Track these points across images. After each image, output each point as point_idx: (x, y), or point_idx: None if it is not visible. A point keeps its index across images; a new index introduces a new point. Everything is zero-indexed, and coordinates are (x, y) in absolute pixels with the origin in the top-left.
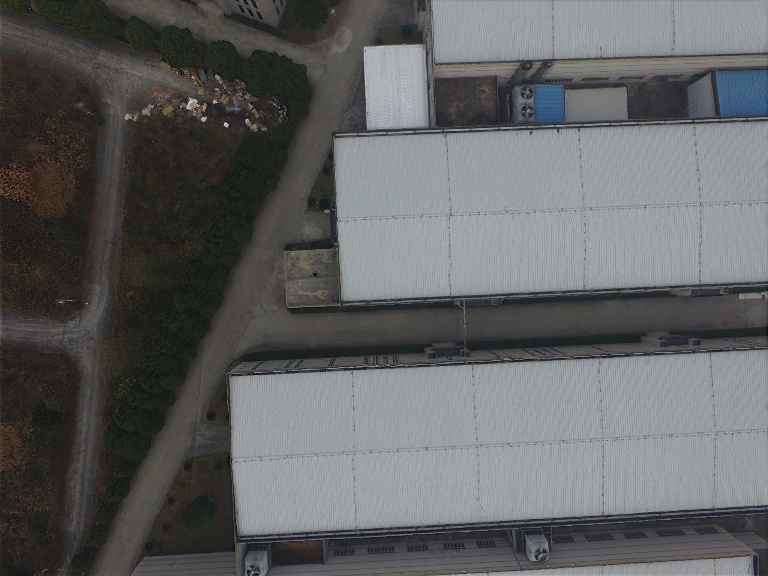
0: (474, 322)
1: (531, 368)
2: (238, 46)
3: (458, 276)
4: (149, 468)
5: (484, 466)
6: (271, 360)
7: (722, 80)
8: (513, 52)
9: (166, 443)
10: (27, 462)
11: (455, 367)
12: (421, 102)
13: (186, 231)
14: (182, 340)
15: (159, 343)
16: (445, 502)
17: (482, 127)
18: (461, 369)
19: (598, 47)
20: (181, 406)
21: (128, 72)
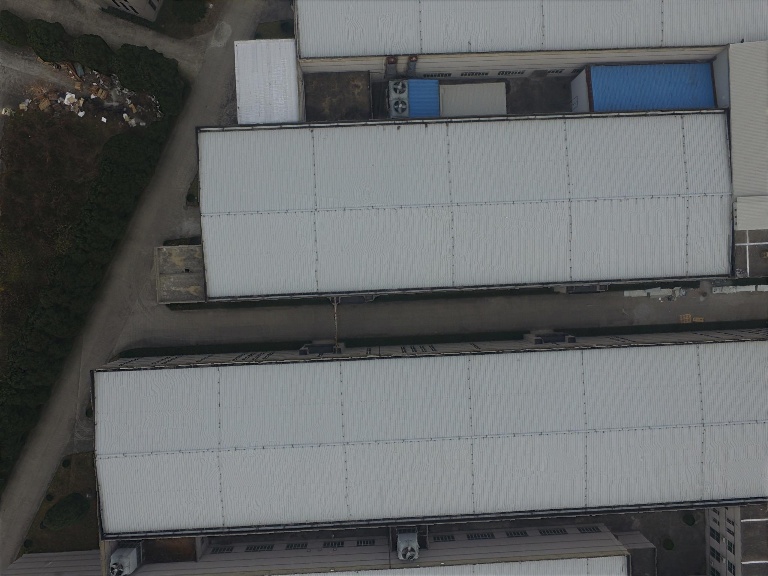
0: (355, 319)
1: (400, 365)
2: (116, 40)
3: (327, 272)
4: (28, 465)
5: (351, 464)
6: (149, 356)
7: (596, 75)
8: (380, 46)
9: (45, 440)
10: None
11: (323, 364)
12: (293, 97)
13: (60, 226)
14: (51, 336)
15: (24, 339)
16: (311, 500)
17: (348, 122)
18: (329, 366)
19: (466, 41)
20: (60, 402)
21: (5, 66)
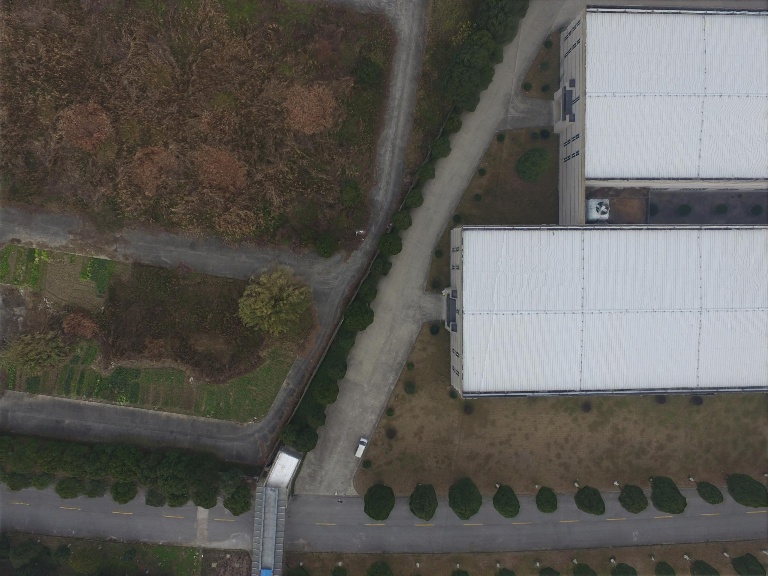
0: None
1: None
2: None
3: None
4: (461, 138)
5: None
6: None
7: None
8: None
9: (479, 114)
10: (345, 119)
11: None
12: None
13: None
14: None
15: None
16: None
17: None
18: None
19: None
20: (497, 76)
21: None
